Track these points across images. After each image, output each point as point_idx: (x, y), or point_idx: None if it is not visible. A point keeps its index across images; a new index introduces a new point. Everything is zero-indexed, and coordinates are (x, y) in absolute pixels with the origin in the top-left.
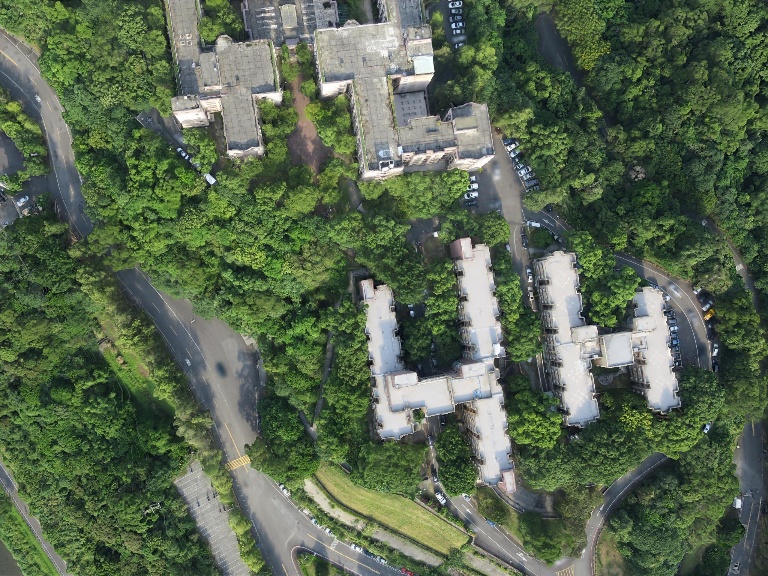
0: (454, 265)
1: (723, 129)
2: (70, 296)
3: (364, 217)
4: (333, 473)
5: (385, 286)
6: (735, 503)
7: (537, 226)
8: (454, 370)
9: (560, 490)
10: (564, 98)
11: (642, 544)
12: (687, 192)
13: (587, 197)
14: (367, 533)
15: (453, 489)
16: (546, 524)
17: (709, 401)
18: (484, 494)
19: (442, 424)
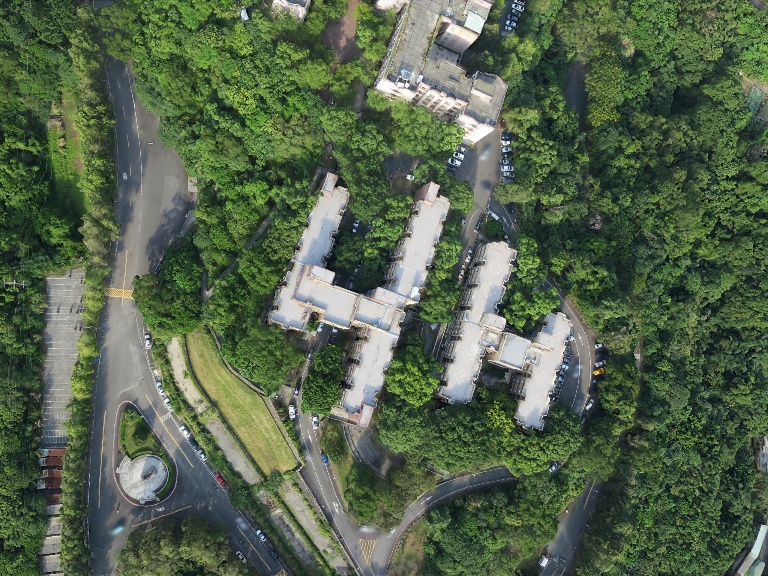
0: (414, 204)
1: (675, 235)
2: (53, 53)
3: (359, 120)
4: (204, 342)
5: (345, 190)
6: (542, 560)
7: (495, 218)
8: (367, 294)
9: (402, 459)
10: (566, 131)
11: (449, 544)
12: (625, 267)
13: (548, 216)
14: (203, 420)
15: (311, 401)
16: (376, 479)
17: (567, 437)
18: (334, 426)
19: (328, 345)
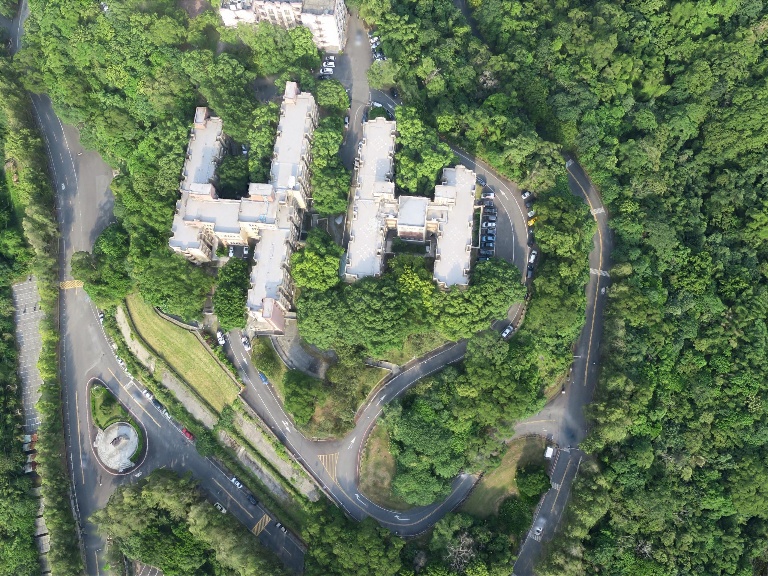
0: None
1: (602, 78)
2: None
3: (215, 56)
4: (139, 300)
5: None
6: (546, 451)
7: (379, 106)
8: None
9: None
10: (437, 13)
11: (406, 435)
12: (548, 120)
13: (429, 87)
14: (158, 377)
15: (221, 313)
16: (305, 378)
17: (497, 284)
18: (259, 339)
19: None
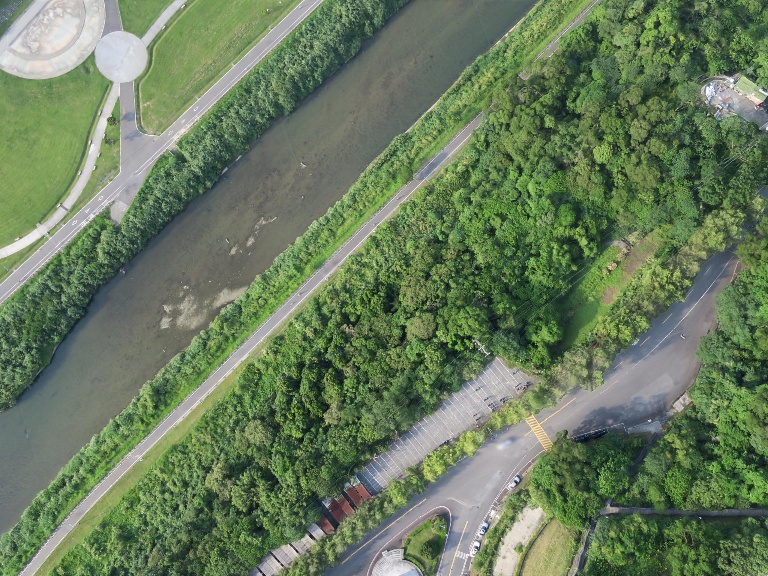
0: None
1: None
2: (692, 205)
3: None
4: (565, 544)
5: None
6: None
7: None
8: None
9: None
10: None
11: None
12: None
13: None
14: None
15: None
16: None
17: None
18: None
19: None
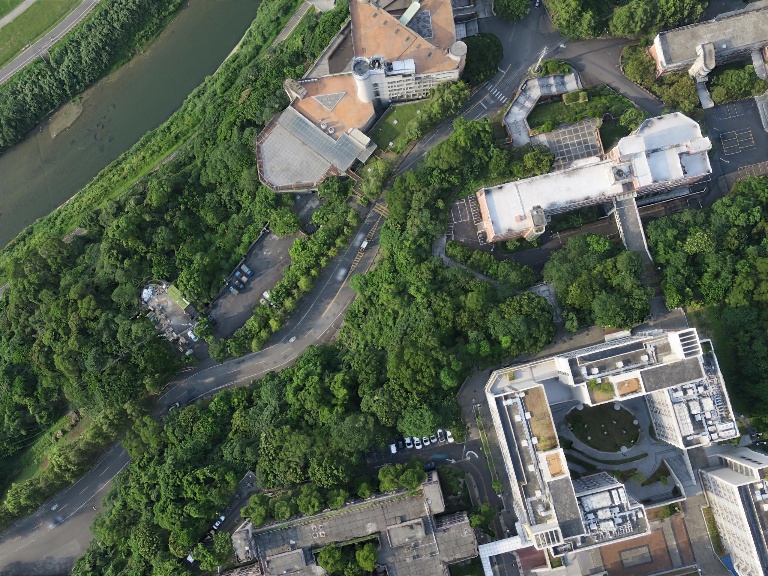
0: None
1: None
2: None
3: None
4: None
5: None
6: None
7: None
8: None
9: None
10: None
11: None
12: None
13: None
14: None
15: None
16: None
17: None
18: None
19: None
